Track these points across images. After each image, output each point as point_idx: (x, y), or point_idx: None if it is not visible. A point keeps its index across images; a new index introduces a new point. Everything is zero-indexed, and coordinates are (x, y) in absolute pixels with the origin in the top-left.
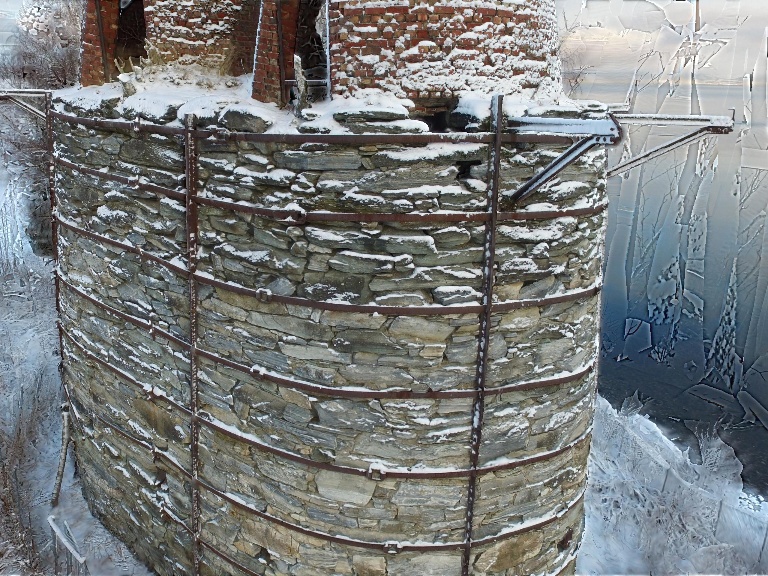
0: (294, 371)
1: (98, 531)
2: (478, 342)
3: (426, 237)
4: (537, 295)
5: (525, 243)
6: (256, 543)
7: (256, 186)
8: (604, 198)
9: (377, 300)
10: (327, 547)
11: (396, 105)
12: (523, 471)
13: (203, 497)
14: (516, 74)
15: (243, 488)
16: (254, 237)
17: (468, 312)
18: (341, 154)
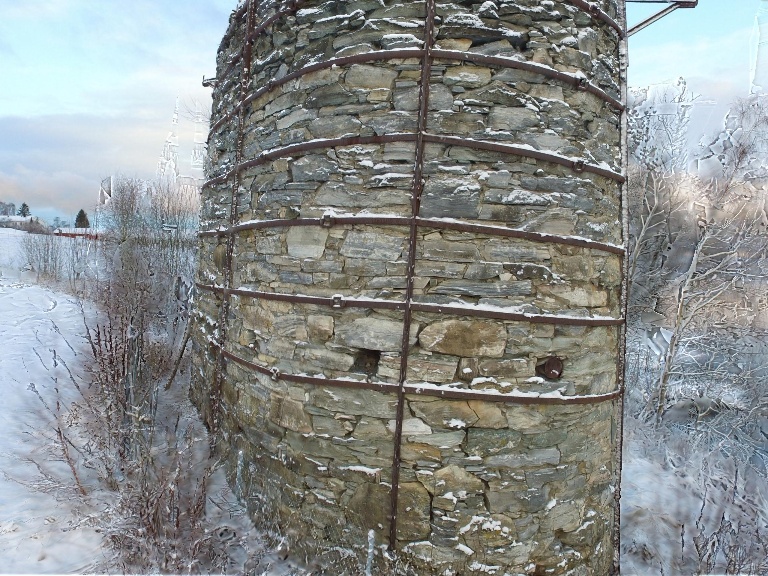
0: (282, 142)
1: (184, 401)
2: (420, 88)
3: None
4: None
5: (472, 3)
6: (250, 328)
7: (277, 2)
8: (592, 2)
9: (336, 54)
10: (291, 311)
11: None
12: (476, 242)
13: None
14: None
15: (247, 274)
16: (274, 46)
17: (409, 56)
18: None
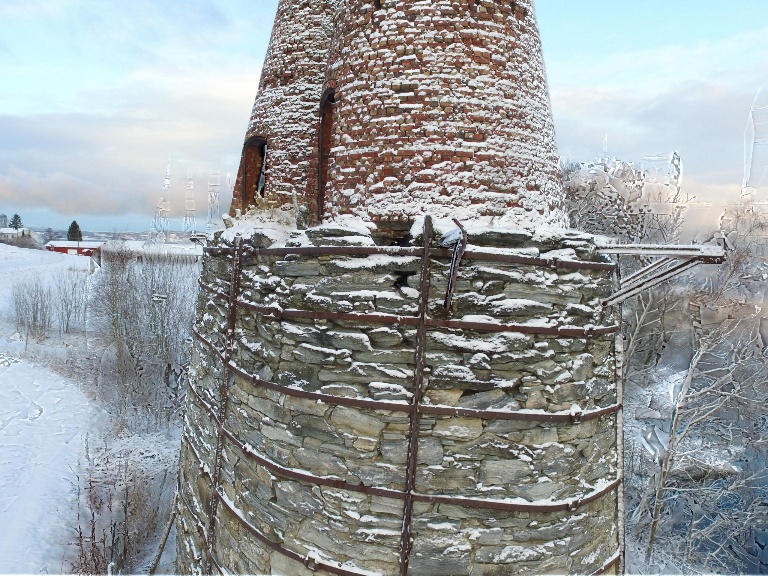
0: (266, 450)
1: None
2: (408, 442)
3: (361, 335)
4: (478, 406)
5: (463, 352)
6: None
7: (261, 290)
8: (587, 325)
9: (322, 388)
10: None
11: (360, 227)
12: None
13: (213, 572)
14: (475, 203)
15: (230, 563)
16: (259, 332)
17: (397, 410)
18: (306, 263)
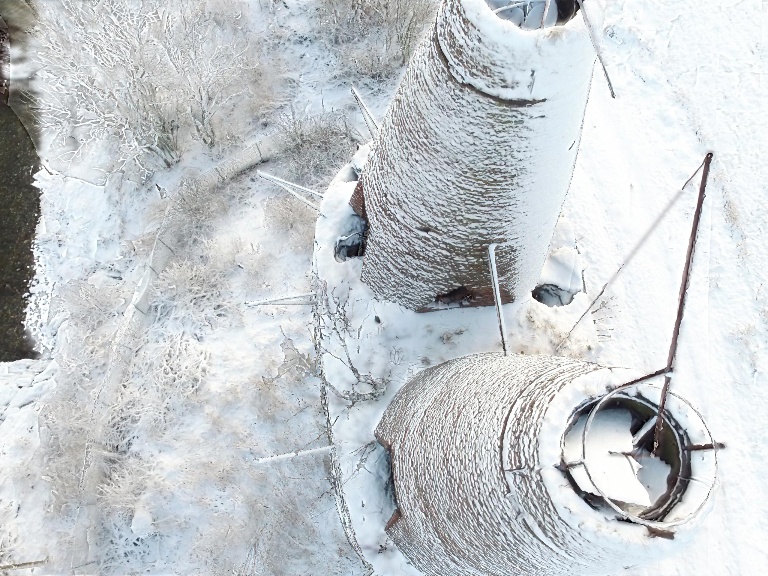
0: None
1: None
2: None
3: None
4: None
5: None
6: None
7: None
8: None
9: None
10: None
11: None
12: None
13: None
14: None
15: None
16: None
17: None
18: None
